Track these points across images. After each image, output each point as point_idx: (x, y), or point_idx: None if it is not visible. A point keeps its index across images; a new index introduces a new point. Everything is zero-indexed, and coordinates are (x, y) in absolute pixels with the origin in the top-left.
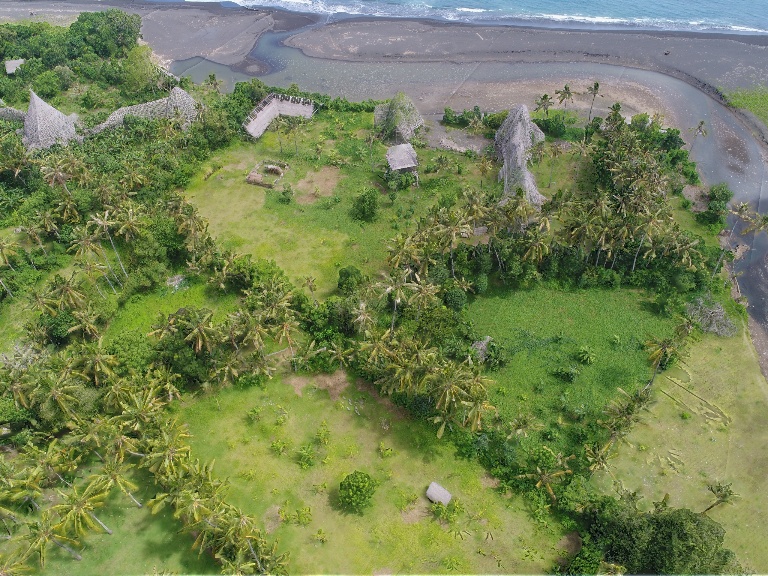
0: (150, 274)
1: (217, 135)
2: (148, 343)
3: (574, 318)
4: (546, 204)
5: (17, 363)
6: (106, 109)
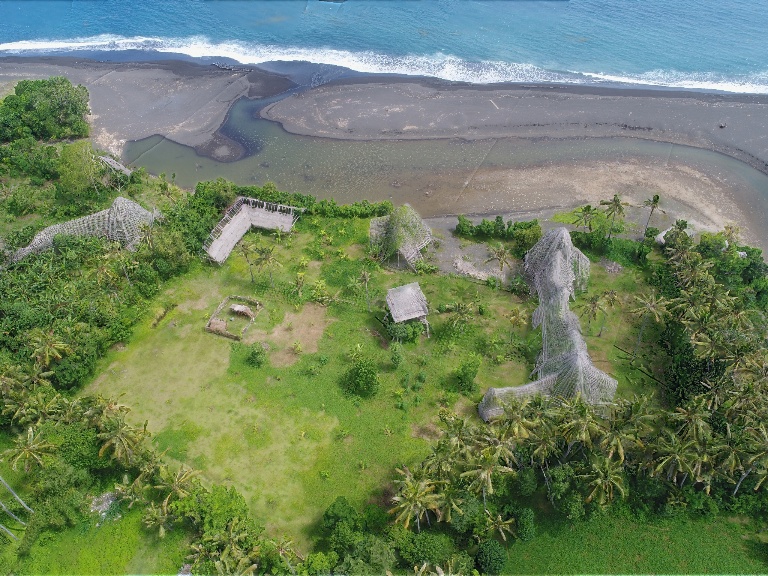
0: (63, 510)
1: (170, 263)
2: None
3: (658, 574)
4: (618, 422)
5: None
6: (38, 215)
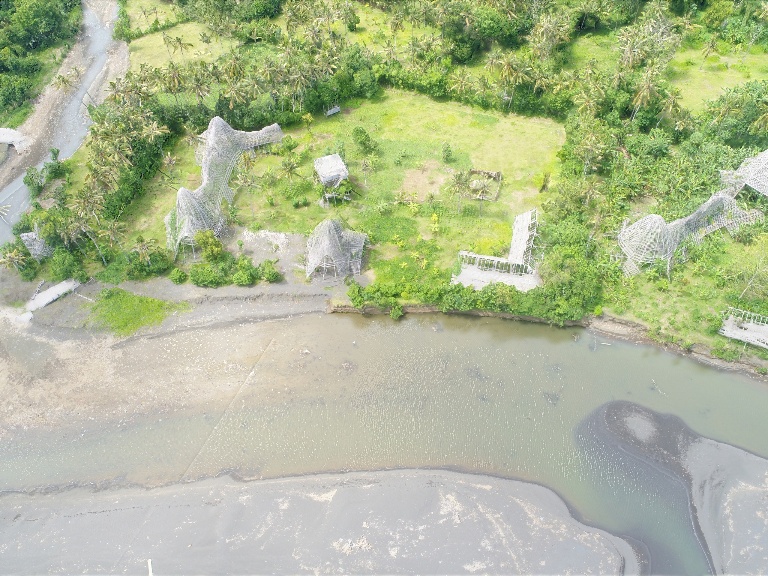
0: None
1: None
2: (482, 31)
3: (217, 100)
4: None
5: None
6: None
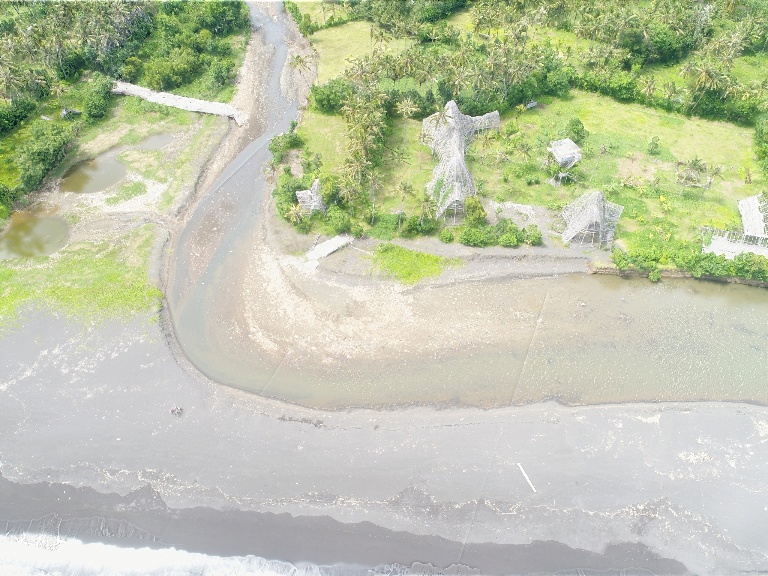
0: None
1: None
2: (654, 44)
3: None
4: None
5: (696, 5)
6: None
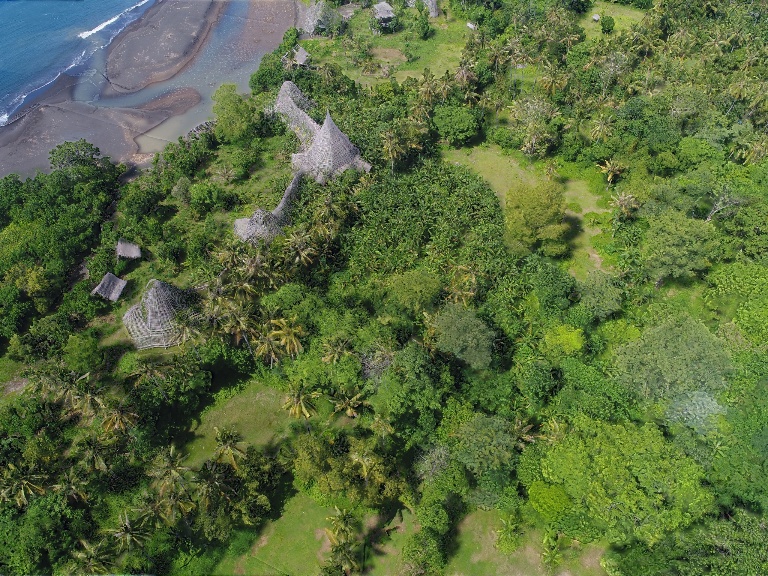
0: None
1: None
2: None
3: None
4: None
5: None
6: (252, 167)
